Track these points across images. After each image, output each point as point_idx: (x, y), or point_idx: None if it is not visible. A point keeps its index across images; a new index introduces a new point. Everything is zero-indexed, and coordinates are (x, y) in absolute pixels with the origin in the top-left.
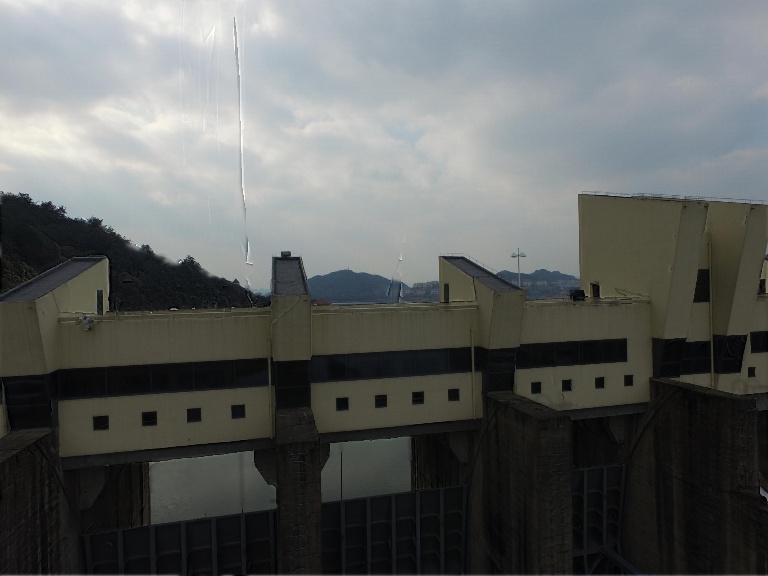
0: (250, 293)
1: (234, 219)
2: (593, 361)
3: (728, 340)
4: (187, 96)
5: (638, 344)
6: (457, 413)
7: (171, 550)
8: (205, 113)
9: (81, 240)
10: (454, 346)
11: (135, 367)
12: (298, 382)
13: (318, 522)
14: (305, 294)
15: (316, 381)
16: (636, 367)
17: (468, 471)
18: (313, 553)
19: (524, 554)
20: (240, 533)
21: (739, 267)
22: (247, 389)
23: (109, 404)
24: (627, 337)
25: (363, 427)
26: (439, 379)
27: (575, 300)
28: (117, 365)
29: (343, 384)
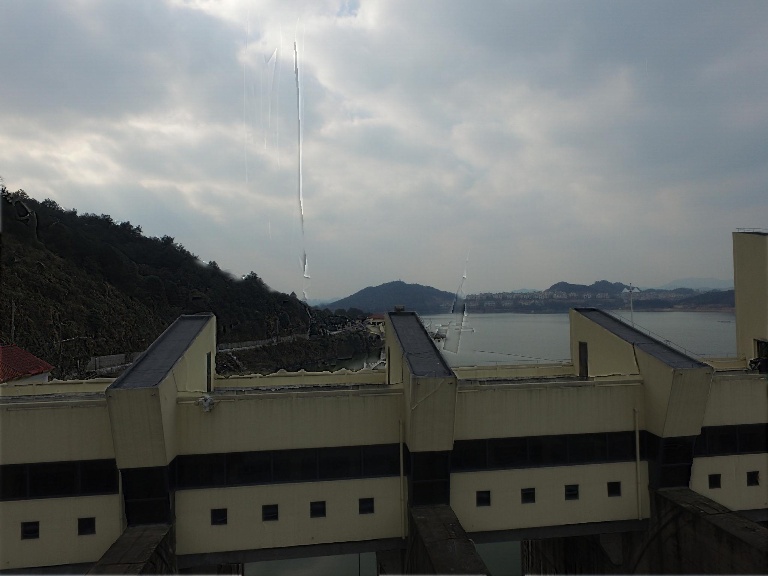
0: None
1: (293, 234)
2: None
3: None
4: (250, 117)
5: None
6: (618, 511)
7: None
8: (266, 132)
9: (155, 258)
10: (614, 429)
11: (255, 453)
12: (436, 475)
13: None
14: (447, 373)
15: (453, 470)
16: None
17: (622, 574)
18: None
19: None
20: None
21: None
22: (376, 480)
23: (228, 495)
24: None
25: (507, 526)
26: (596, 470)
27: (761, 372)
28: (236, 451)
29: (484, 475)
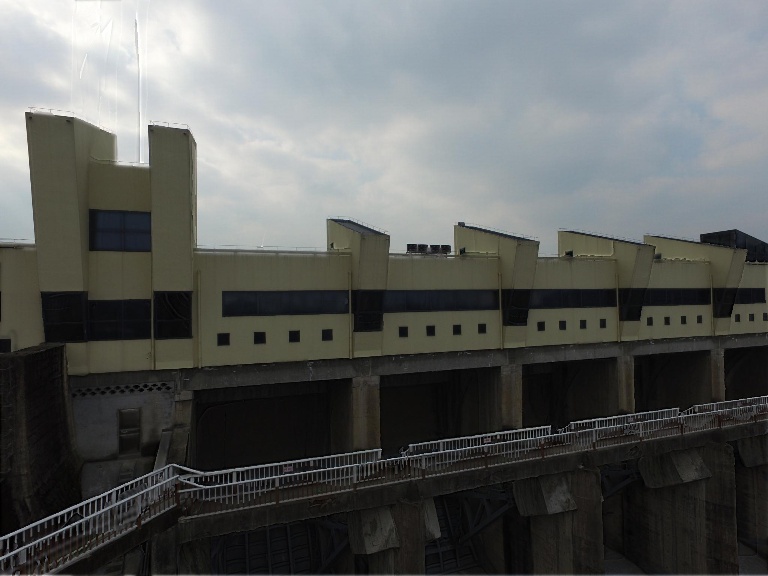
0: None
1: None
2: None
3: (164, 297)
4: (80, 90)
5: (22, 300)
6: None
7: None
8: (99, 109)
9: None
10: None
11: None
12: None
13: None
14: None
15: None
16: (16, 329)
17: None
18: None
19: None
20: None
21: (151, 204)
22: None
23: None
24: (2, 290)
25: None
26: None
27: None
28: None
29: None
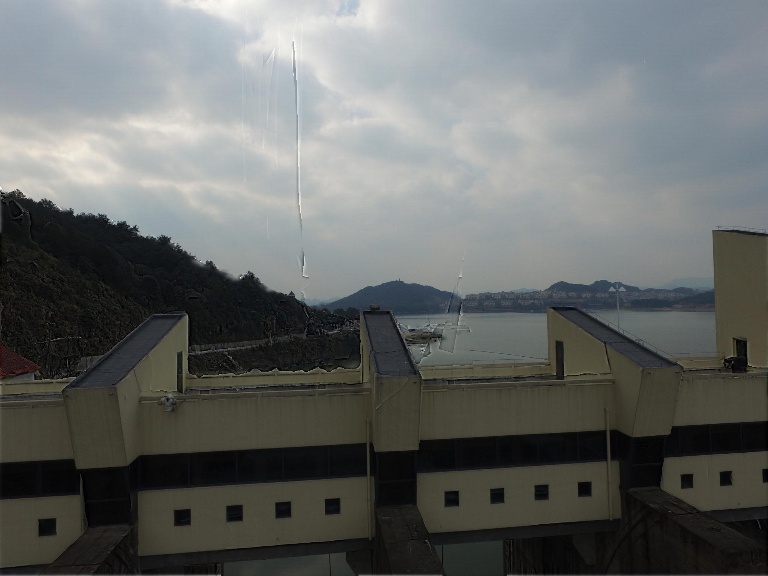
0: (306, 307)
1: (291, 233)
2: (759, 448)
3: None
4: (248, 116)
5: None
6: (589, 511)
7: None
8: (265, 132)
9: (152, 257)
10: (585, 429)
11: (219, 453)
12: (402, 475)
13: None
14: (413, 372)
15: (421, 471)
16: None
17: (596, 575)
18: None
19: None
20: None
21: None
22: (342, 480)
23: (191, 496)
24: None
25: (476, 527)
26: (567, 469)
27: (734, 371)
28: (200, 451)
29: (452, 475)
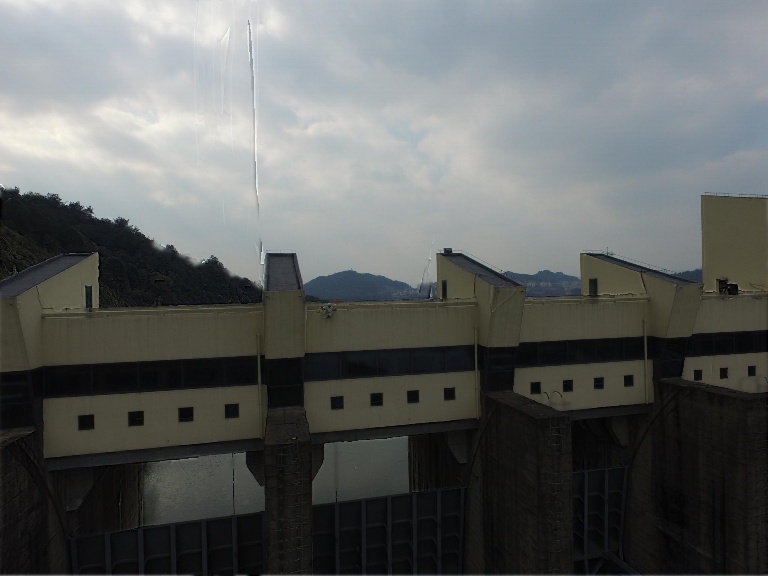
0: None
1: (248, 220)
2: (746, 351)
3: None
4: (201, 97)
5: None
6: (631, 398)
7: (374, 523)
8: (220, 114)
9: (110, 240)
10: (629, 335)
11: (364, 352)
12: (504, 367)
13: (570, 489)
14: None
15: None
16: None
17: (628, 453)
18: (567, 517)
19: (721, 524)
20: (436, 508)
21: None
22: (457, 373)
23: (343, 386)
24: None
25: None
26: (616, 366)
27: (730, 294)
28: (350, 350)
29: (536, 370)
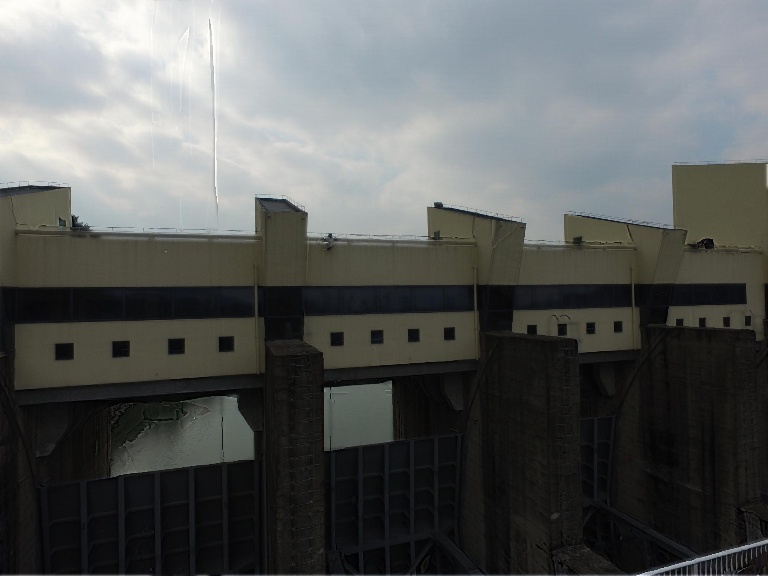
0: None
1: (207, 222)
2: (721, 302)
3: None
4: (158, 96)
5: (754, 289)
6: (621, 343)
7: (370, 473)
8: (178, 114)
9: None
10: (618, 282)
11: (364, 288)
12: (503, 306)
13: (578, 413)
14: None
15: None
16: (753, 309)
17: (615, 403)
18: (575, 440)
19: (711, 456)
20: (433, 455)
21: None
22: (456, 313)
23: (344, 321)
24: (746, 282)
25: None
26: (607, 312)
27: (706, 247)
28: (350, 285)
29: (532, 312)
